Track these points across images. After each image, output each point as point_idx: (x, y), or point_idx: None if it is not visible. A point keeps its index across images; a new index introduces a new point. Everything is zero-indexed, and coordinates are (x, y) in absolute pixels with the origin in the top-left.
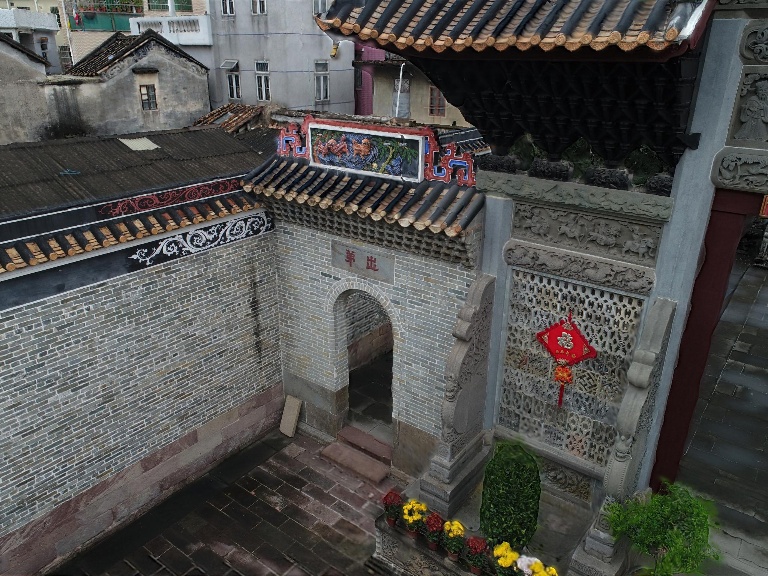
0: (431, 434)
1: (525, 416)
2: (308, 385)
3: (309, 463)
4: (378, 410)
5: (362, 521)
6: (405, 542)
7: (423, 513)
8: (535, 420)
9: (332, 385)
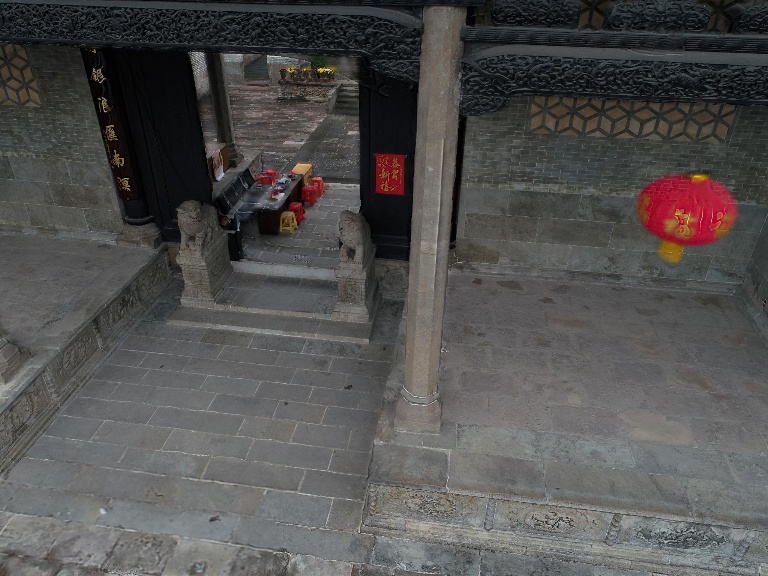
0: (284, 64)
1: None
2: (226, 64)
3: (236, 93)
4: (252, 79)
5: (268, 97)
6: (290, 83)
7: (294, 70)
8: None
9: (238, 59)
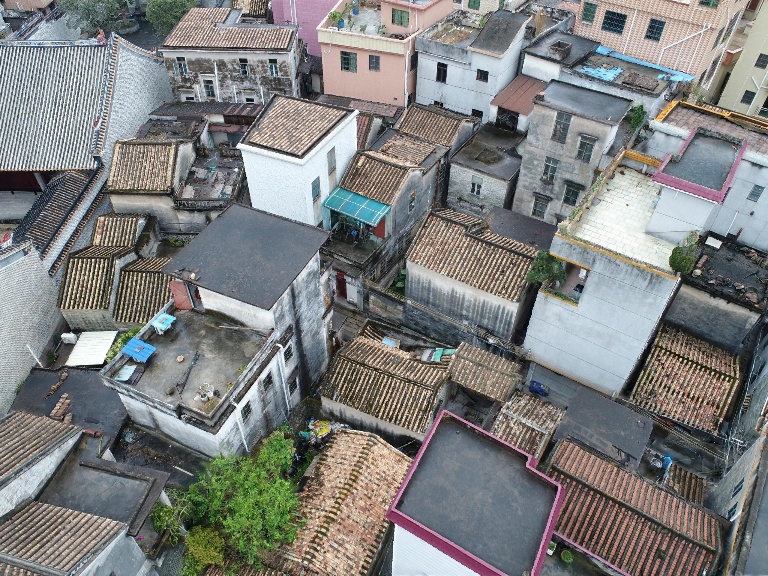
0: None
1: (199, 1)
2: None
3: None
4: None
5: None
6: None
7: None
8: (197, 1)
9: None
